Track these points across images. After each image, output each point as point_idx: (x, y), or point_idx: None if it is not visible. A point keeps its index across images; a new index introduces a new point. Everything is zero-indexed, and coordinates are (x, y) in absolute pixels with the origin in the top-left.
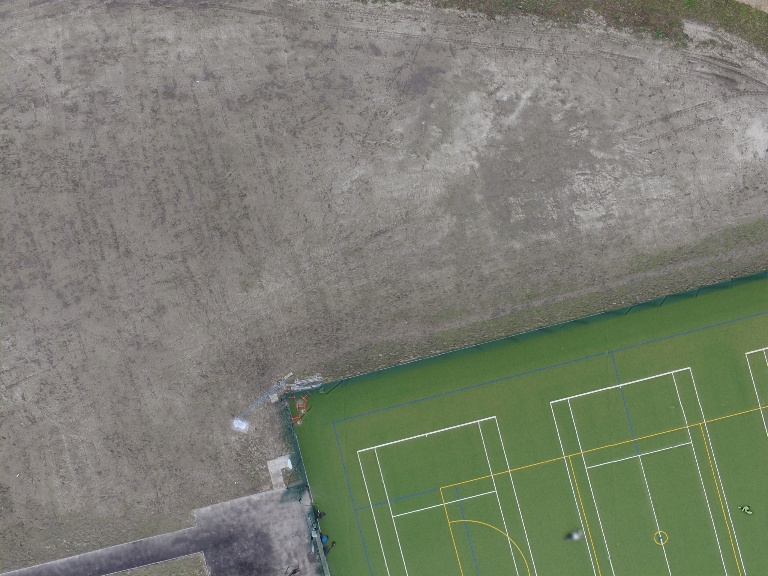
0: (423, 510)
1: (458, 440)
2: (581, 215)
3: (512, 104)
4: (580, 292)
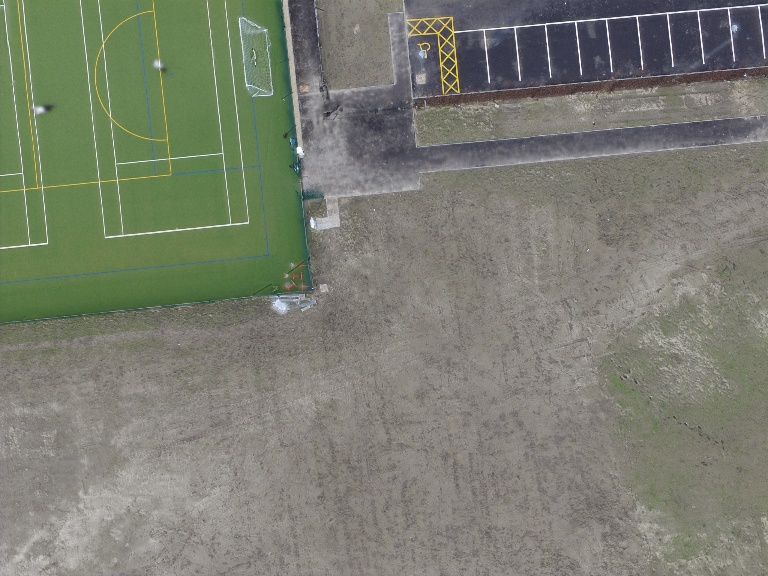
0: (192, 156)
1: (146, 220)
2: None
3: (35, 550)
4: (1, 349)
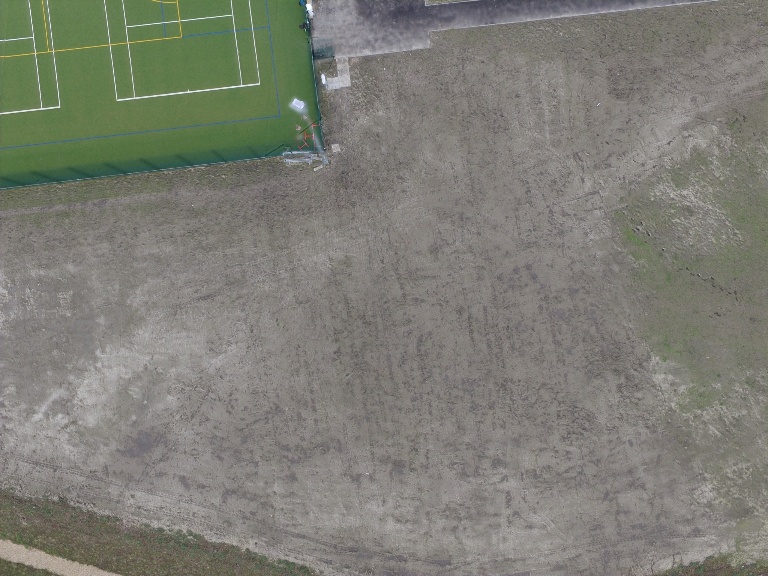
0: (202, 18)
1: (157, 82)
2: (1, 289)
3: (54, 409)
4: (15, 213)
